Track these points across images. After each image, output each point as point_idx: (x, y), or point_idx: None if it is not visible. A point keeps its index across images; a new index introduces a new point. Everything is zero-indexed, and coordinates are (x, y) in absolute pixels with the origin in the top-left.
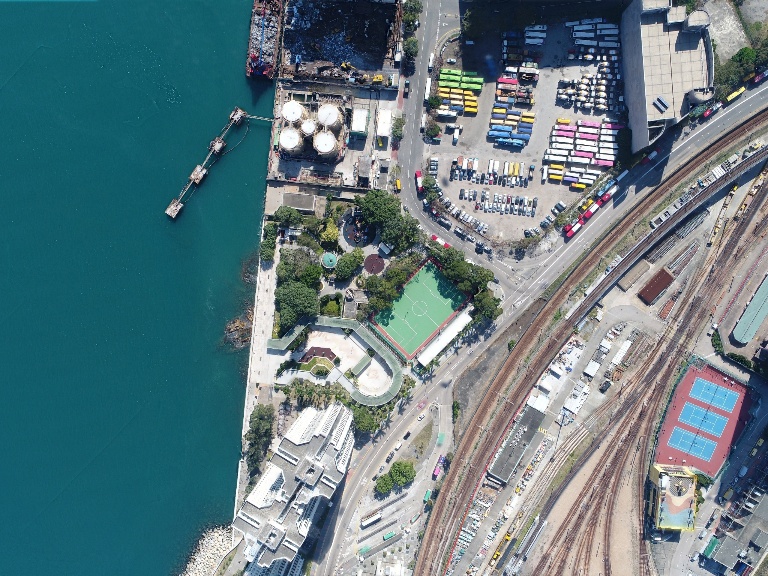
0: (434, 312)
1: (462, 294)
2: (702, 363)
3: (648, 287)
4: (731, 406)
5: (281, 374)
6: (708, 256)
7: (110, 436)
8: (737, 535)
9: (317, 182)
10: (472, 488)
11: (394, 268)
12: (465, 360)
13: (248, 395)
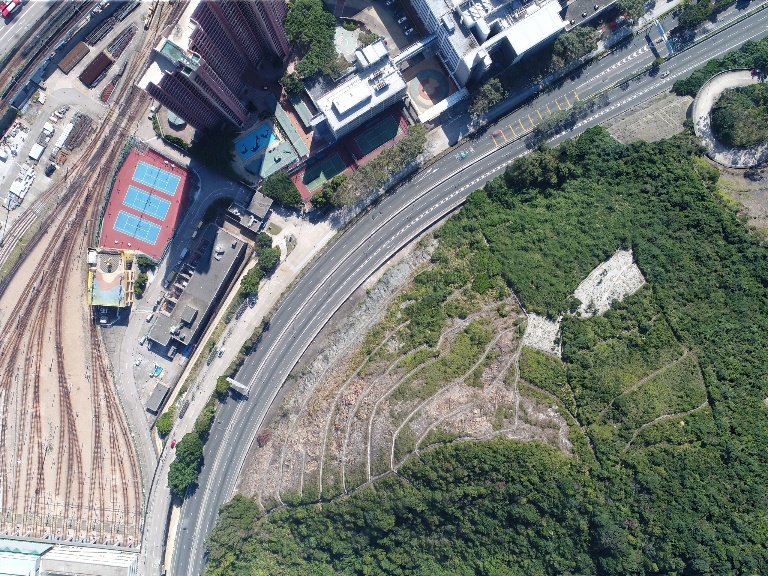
0: None
1: None
2: (144, 147)
3: (87, 69)
4: (173, 189)
5: None
6: (146, 40)
7: None
8: (171, 313)
9: None
10: None
11: None
12: None
13: None
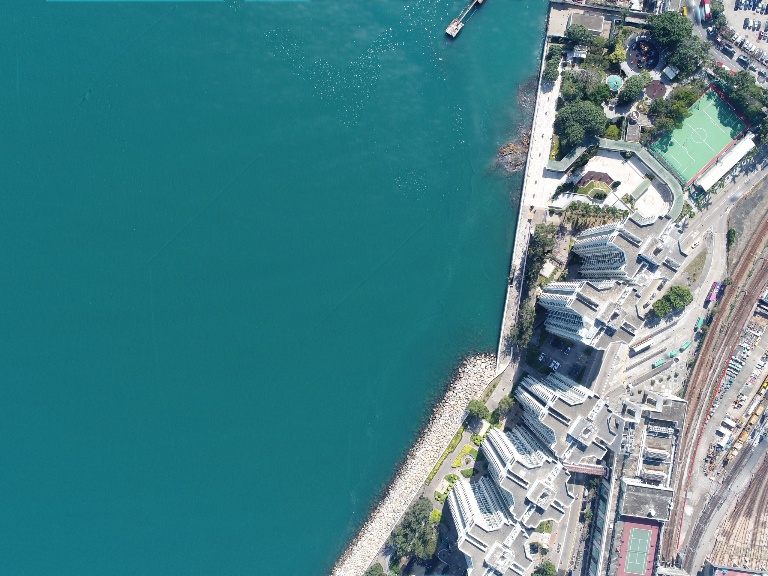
0: (713, 140)
1: (741, 123)
2: None
3: None
4: None
5: (557, 197)
6: None
7: (396, 245)
8: None
9: (606, 4)
10: (745, 315)
11: (683, 90)
12: (742, 188)
13: (521, 219)
